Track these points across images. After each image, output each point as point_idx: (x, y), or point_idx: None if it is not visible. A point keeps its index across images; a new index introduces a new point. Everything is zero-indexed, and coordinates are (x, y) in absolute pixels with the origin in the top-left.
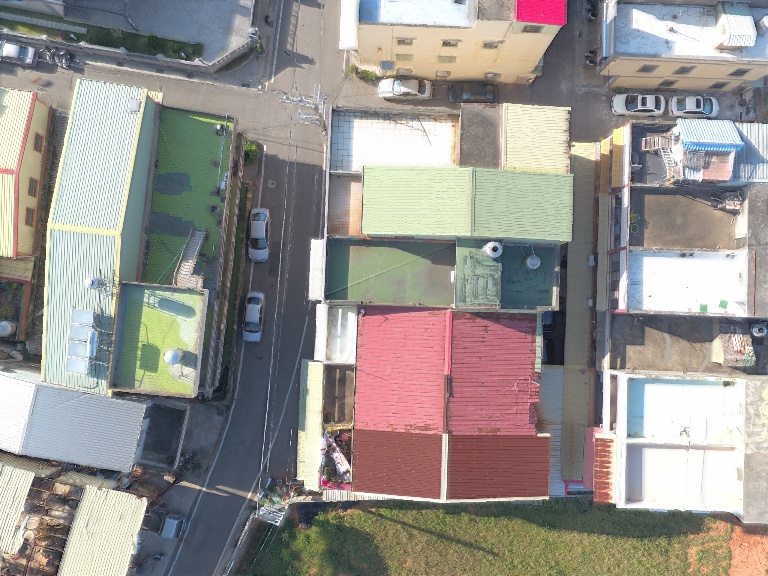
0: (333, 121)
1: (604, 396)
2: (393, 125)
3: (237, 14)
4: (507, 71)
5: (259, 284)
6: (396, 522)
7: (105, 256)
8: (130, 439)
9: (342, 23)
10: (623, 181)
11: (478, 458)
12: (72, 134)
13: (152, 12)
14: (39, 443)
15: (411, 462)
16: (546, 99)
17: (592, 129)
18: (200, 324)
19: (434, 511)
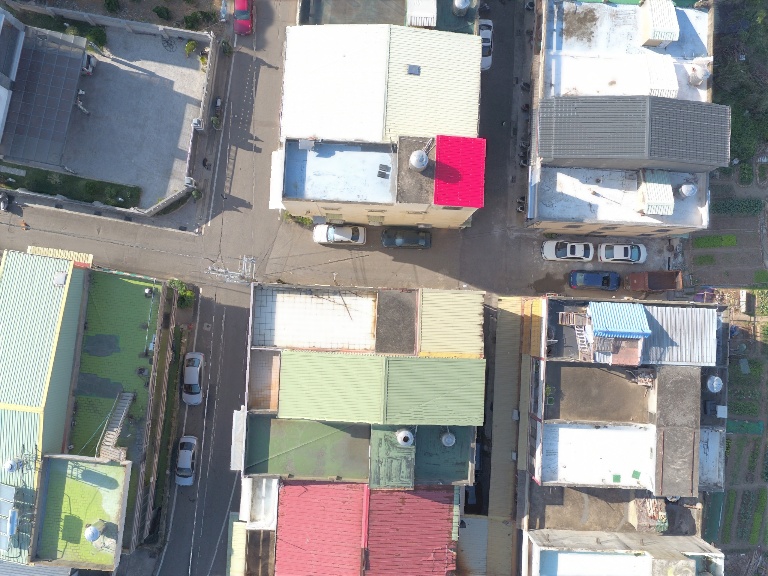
0: (256, 295)
1: (523, 555)
2: (315, 299)
3: (175, 157)
4: (437, 223)
5: (193, 426)
6: None
7: (28, 432)
8: None
9: (272, 183)
10: (540, 352)
11: None
12: None
13: (91, 155)
14: None
15: None
16: (478, 244)
17: (523, 273)
18: (121, 498)
19: None
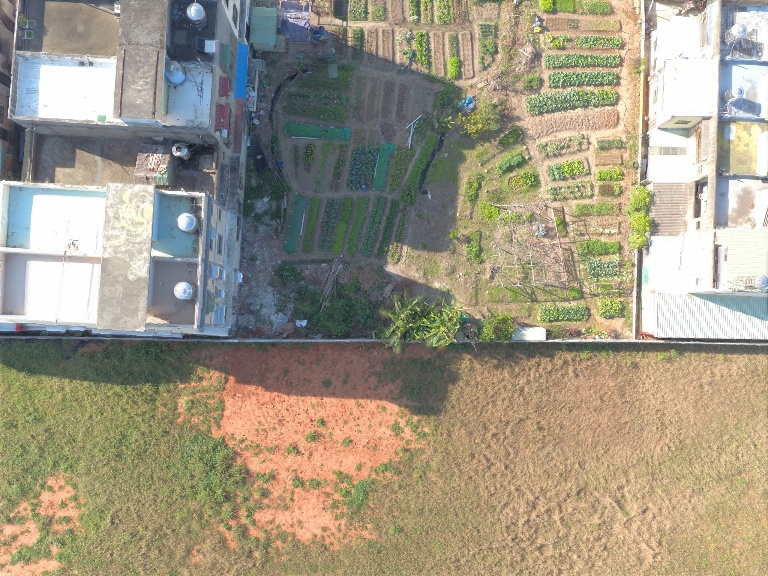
0: None
1: None
2: None
3: None
4: None
5: None
6: None
7: None
8: None
9: None
10: None
11: None
12: None
13: None
14: None
15: None
16: None
17: None
18: None
19: None
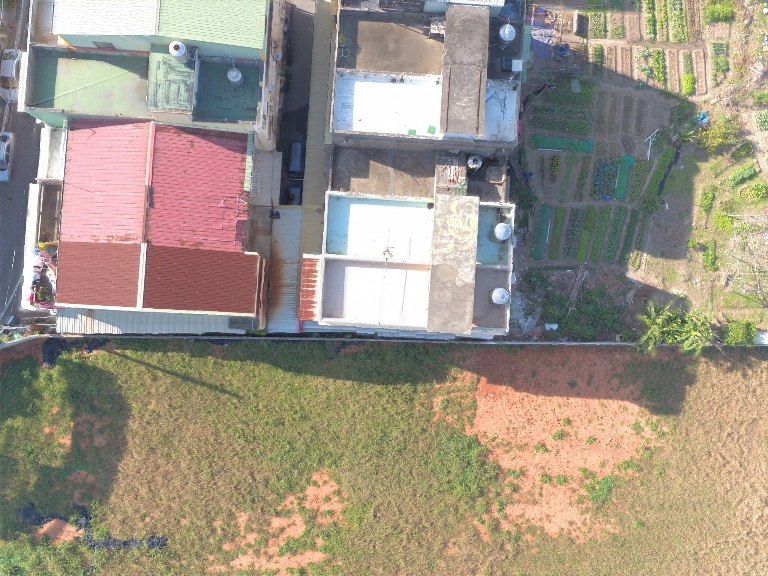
0: None
1: None
2: None
3: None
4: None
5: (12, 125)
6: (141, 363)
7: None
8: None
9: None
10: None
11: (179, 270)
12: None
13: None
14: None
15: (111, 272)
16: None
17: None
18: None
19: (181, 354)
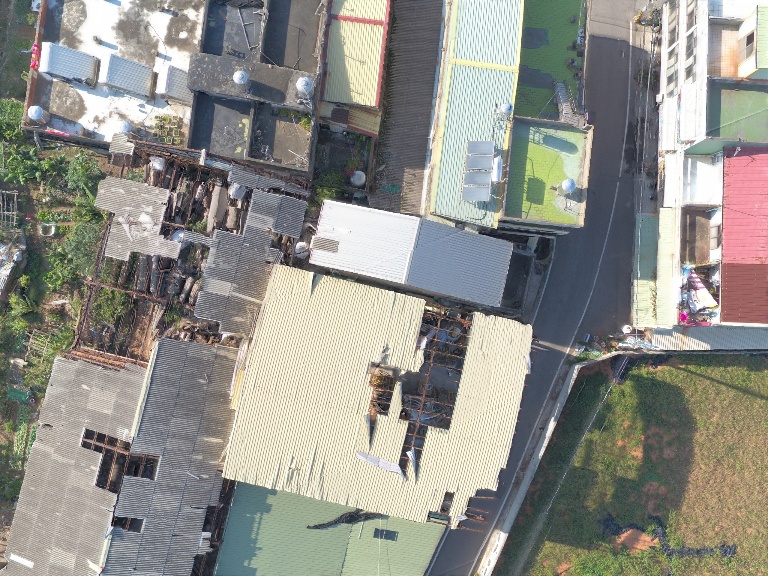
0: None
1: None
2: None
3: None
4: None
5: None
6: (706, 378)
7: (502, 91)
8: (500, 275)
9: None
10: None
11: None
12: None
13: None
14: (423, 274)
15: None
16: None
17: None
18: (589, 157)
19: (739, 369)
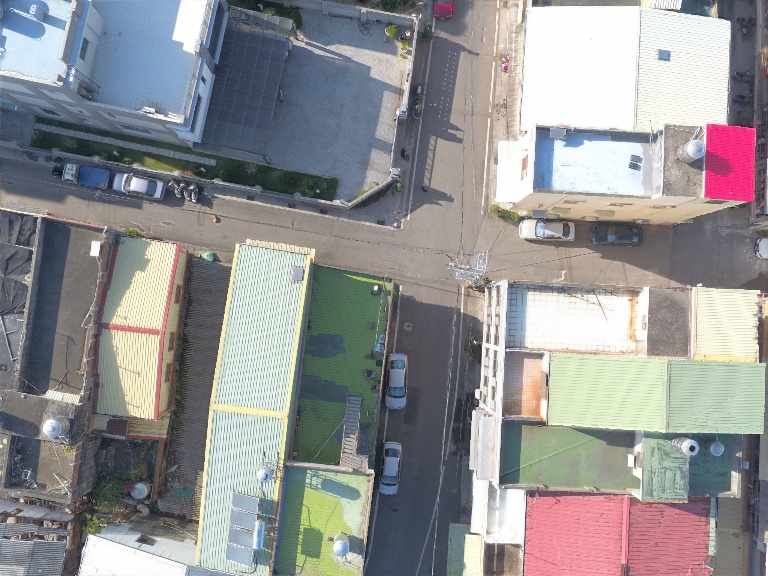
0: None
1: (767, 570)
2: (567, 298)
3: (372, 147)
4: (658, 219)
5: (394, 432)
6: None
7: (270, 438)
8: None
9: (499, 175)
10: None
11: None
12: (233, 305)
13: (284, 144)
14: None
15: None
16: (689, 241)
17: (735, 272)
18: (368, 510)
19: None
